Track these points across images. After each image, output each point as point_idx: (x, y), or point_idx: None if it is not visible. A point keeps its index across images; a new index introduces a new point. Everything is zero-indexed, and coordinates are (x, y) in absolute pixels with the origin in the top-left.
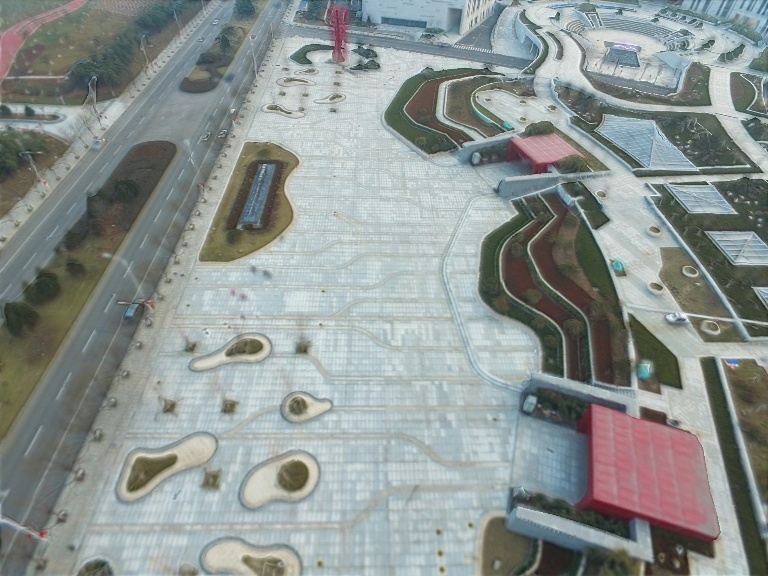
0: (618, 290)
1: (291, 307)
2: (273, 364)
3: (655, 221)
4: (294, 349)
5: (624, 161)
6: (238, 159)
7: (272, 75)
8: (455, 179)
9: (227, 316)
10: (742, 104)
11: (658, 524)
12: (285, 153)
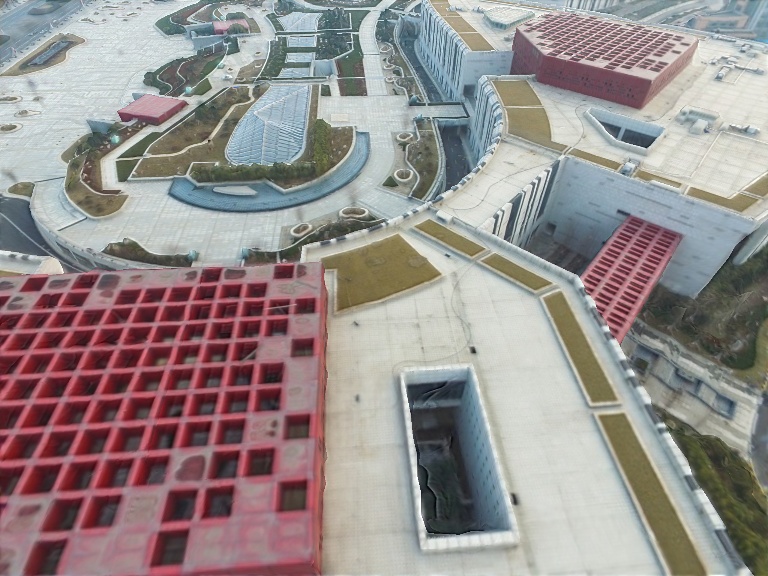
0: (211, 72)
1: (40, 88)
2: (19, 104)
3: (265, 51)
4: (33, 99)
5: (274, 29)
6: (47, 41)
7: (96, 5)
8: (176, 45)
9: (4, 92)
10: (395, 5)
11: (140, 117)
12: (78, 38)
